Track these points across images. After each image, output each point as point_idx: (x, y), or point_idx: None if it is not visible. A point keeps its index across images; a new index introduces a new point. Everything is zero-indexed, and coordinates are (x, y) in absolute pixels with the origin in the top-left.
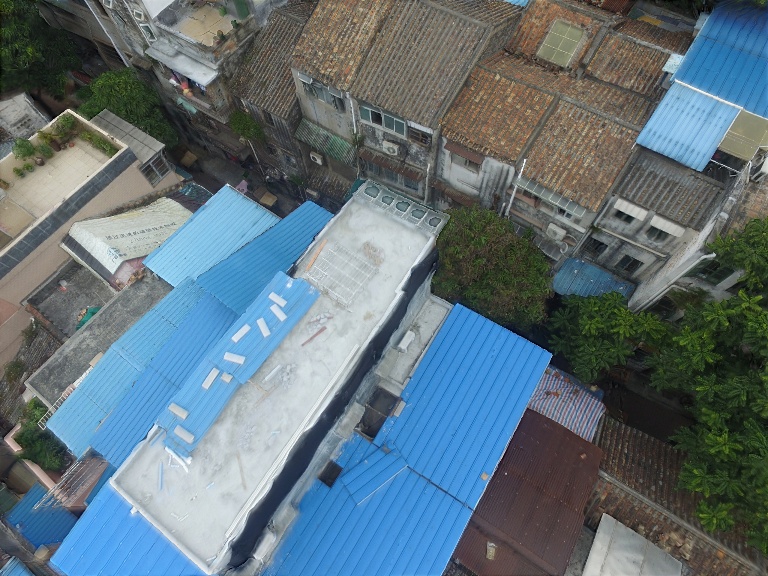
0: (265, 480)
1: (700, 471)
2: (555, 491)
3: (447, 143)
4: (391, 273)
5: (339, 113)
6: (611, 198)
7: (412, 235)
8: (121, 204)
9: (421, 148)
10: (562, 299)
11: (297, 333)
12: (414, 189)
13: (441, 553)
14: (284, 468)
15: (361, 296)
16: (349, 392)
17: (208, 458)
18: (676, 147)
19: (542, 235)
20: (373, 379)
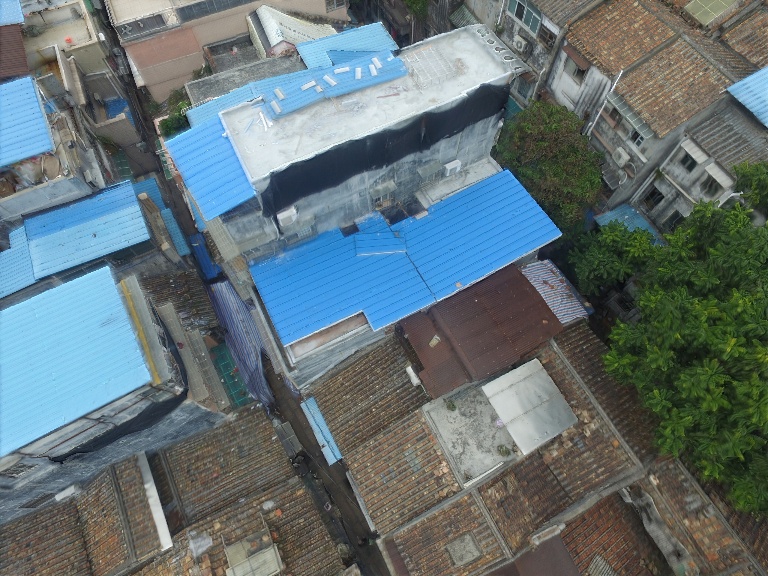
0: (310, 155)
1: (626, 325)
2: (507, 330)
3: (566, 45)
4: (465, 83)
5: (493, 1)
6: (683, 138)
7: (496, 68)
8: (299, 11)
9: (544, 49)
10: (600, 226)
11: (378, 90)
12: (524, 96)
13: (398, 312)
14: (326, 153)
15: (435, 87)
16: (392, 154)
17: (282, 129)
18: (761, 104)
19: (610, 163)
20: (413, 177)
